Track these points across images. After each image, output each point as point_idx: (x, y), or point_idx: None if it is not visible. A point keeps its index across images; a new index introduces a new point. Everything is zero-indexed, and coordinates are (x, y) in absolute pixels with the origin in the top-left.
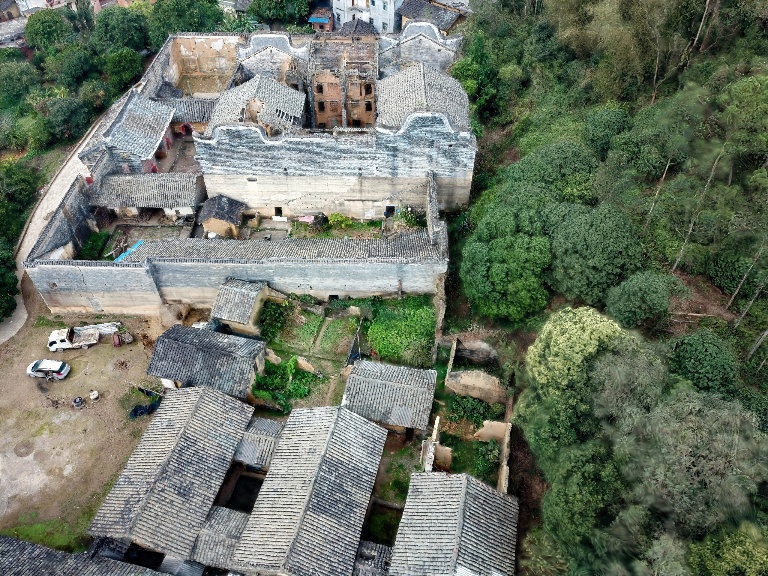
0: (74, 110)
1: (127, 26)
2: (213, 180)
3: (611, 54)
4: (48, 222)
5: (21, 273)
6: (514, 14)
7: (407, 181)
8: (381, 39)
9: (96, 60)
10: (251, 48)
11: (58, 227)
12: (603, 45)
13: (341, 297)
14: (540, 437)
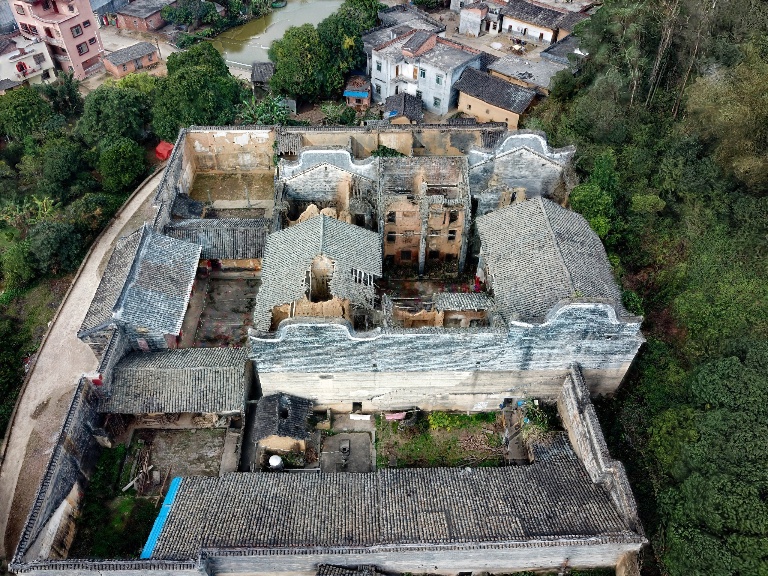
0: (63, 239)
1: (124, 112)
2: (272, 378)
3: None
4: (44, 476)
5: (3, 522)
6: (616, 103)
7: (539, 373)
8: (471, 153)
9: (85, 154)
10: (300, 165)
11: (58, 474)
12: None
13: (476, 573)
14: None
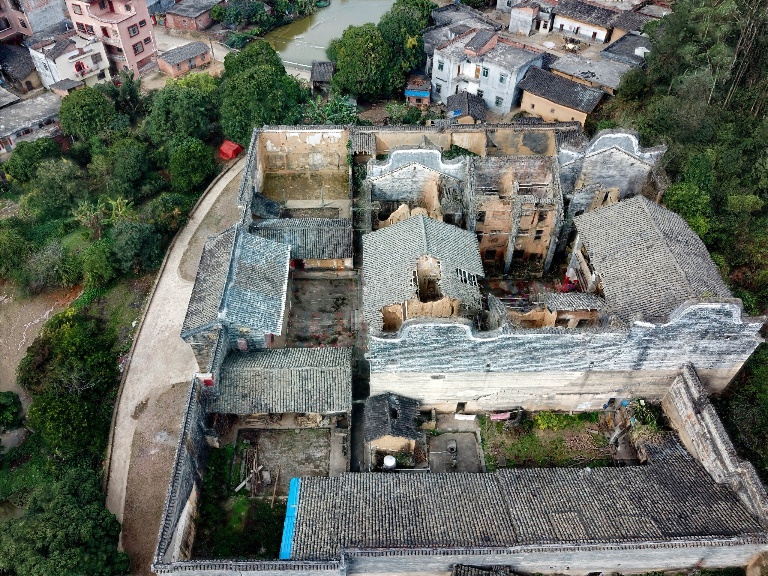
0: (145, 239)
1: (192, 112)
2: (383, 378)
3: None
4: (173, 476)
5: (119, 522)
6: None
7: (650, 373)
8: (561, 153)
9: (153, 154)
10: (389, 165)
11: (183, 475)
12: None
13: (605, 573)
14: None
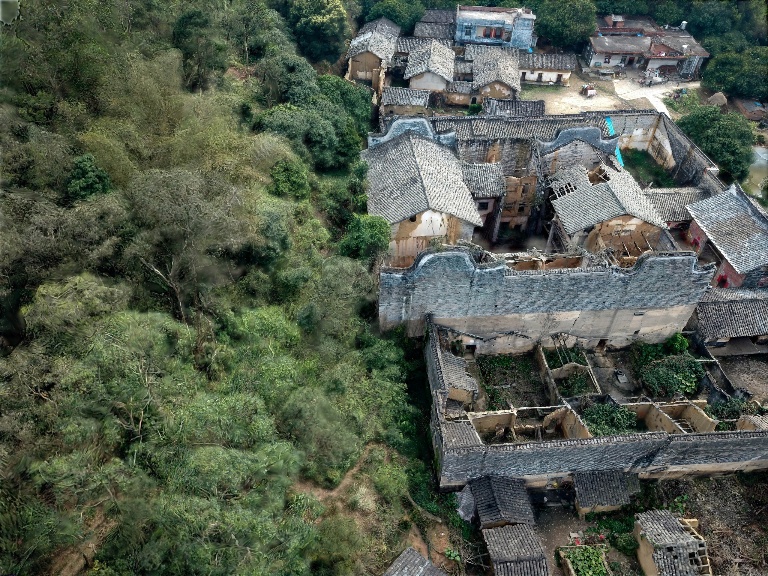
0: None
1: None
2: None
3: None
4: None
5: None
6: None
7: None
8: None
9: None
10: None
11: None
12: None
13: None
14: (345, 4)
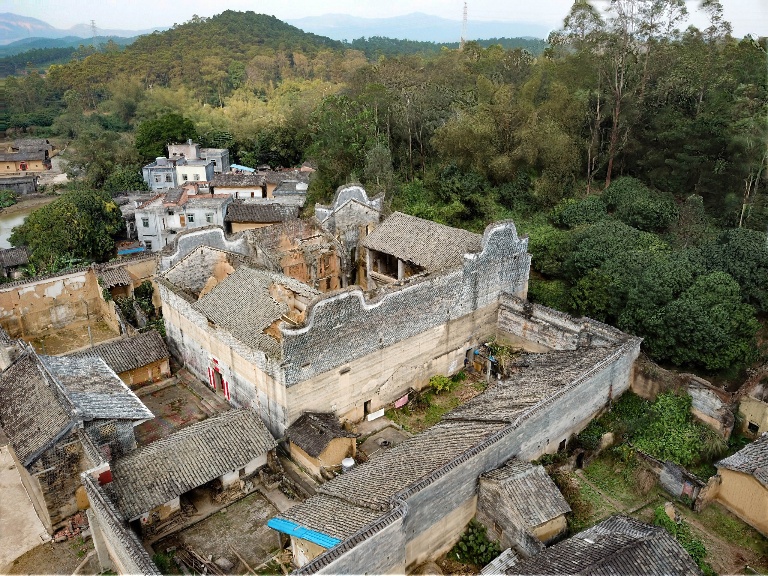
0: None
1: None
2: (298, 392)
3: (558, 159)
4: (142, 557)
5: None
6: None
7: (484, 311)
8: (317, 212)
9: None
10: (177, 254)
11: None
12: (554, 152)
13: (567, 440)
14: None
